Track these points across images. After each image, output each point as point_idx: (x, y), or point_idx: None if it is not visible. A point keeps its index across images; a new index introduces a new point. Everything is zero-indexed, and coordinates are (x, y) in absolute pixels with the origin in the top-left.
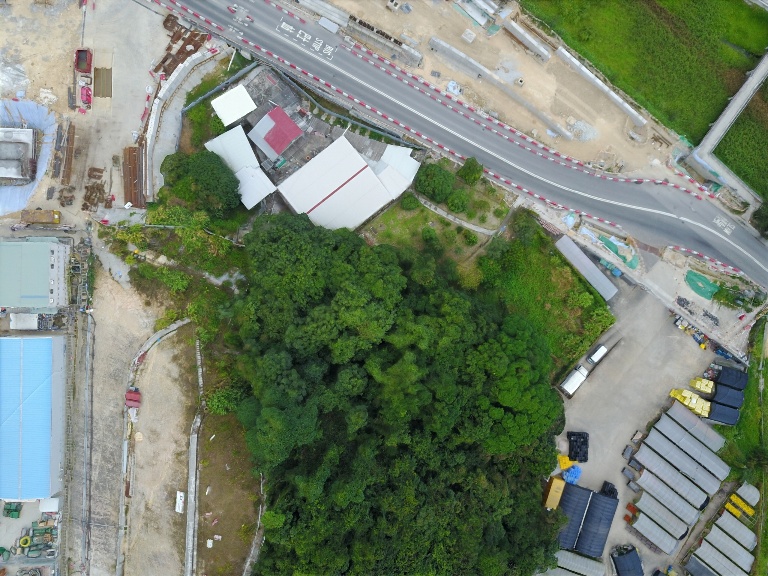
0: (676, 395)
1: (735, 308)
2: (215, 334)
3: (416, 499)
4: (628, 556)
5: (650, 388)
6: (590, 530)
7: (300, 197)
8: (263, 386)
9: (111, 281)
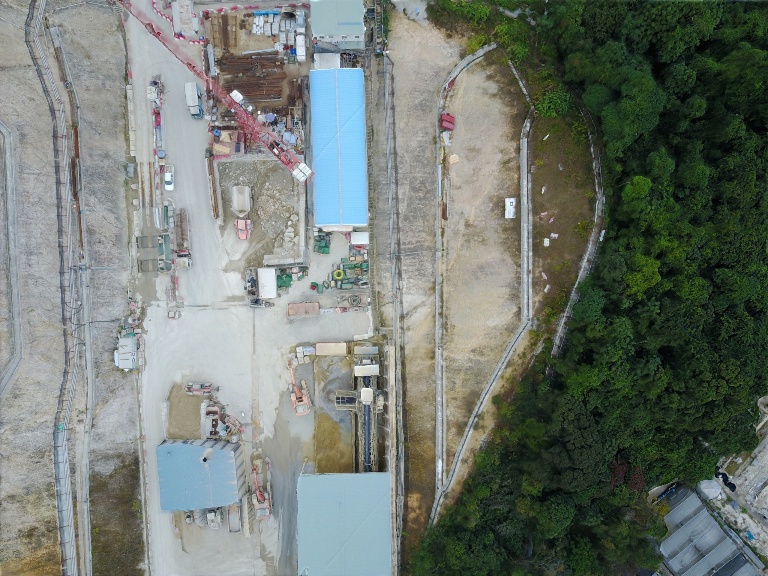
0: None
1: None
2: (526, 54)
3: (755, 187)
4: None
5: None
6: None
7: None
8: (611, 69)
9: (406, 21)
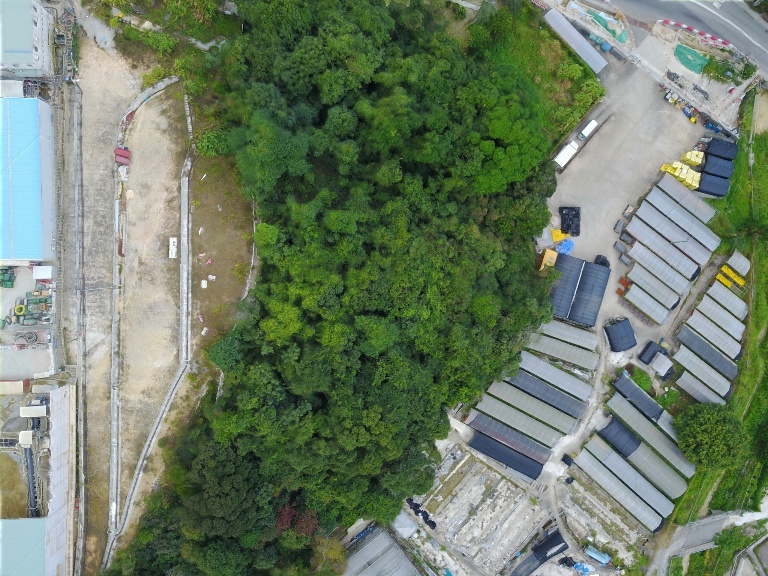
0: (667, 168)
1: (725, 81)
2: (203, 89)
3: (409, 233)
4: (621, 324)
5: (641, 163)
6: (583, 297)
7: None
8: (252, 111)
9: (96, 49)
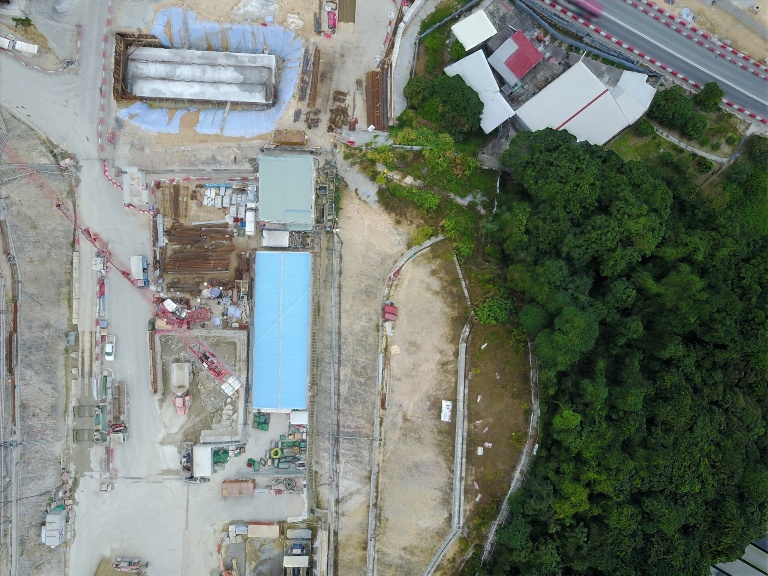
0: None
1: None
2: (472, 250)
3: (690, 410)
4: None
5: None
6: None
7: (539, 121)
8: (548, 291)
9: (357, 201)
